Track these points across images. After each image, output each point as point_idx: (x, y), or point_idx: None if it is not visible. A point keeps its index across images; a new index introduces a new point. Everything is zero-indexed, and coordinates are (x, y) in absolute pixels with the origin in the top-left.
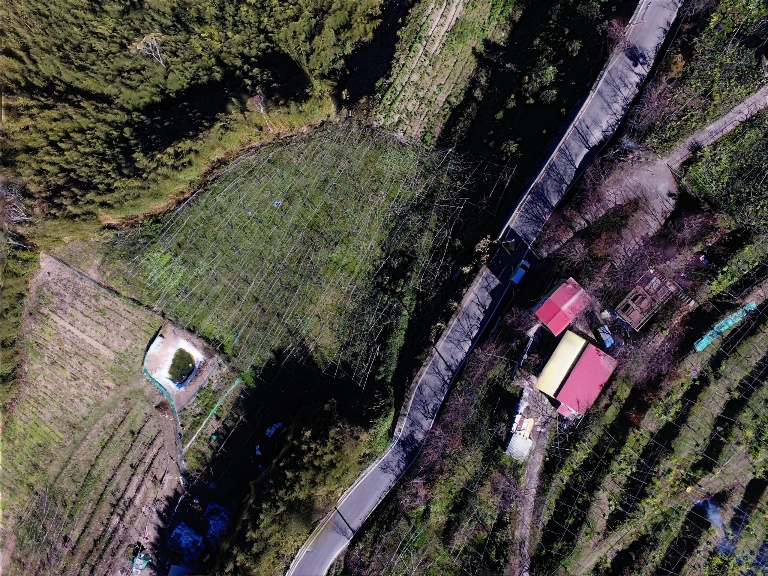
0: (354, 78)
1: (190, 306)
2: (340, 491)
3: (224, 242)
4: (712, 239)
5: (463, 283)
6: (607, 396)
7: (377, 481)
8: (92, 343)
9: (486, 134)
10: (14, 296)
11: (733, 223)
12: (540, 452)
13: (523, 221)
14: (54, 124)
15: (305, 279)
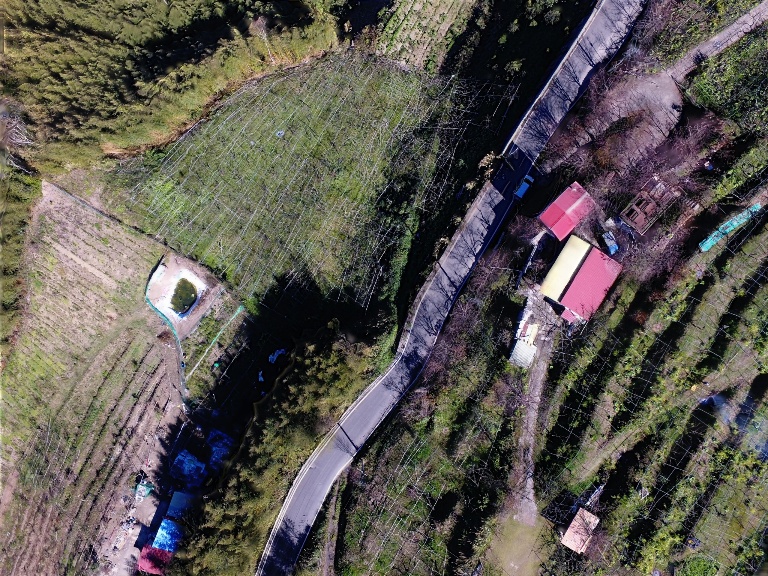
0: (356, 13)
1: (192, 234)
2: (343, 407)
3: (226, 171)
4: (717, 146)
5: (466, 200)
6: (611, 301)
7: (380, 398)
8: (94, 272)
9: (489, 60)
10: (16, 223)
11: (738, 129)
12: (544, 360)
13: (527, 137)
14: (56, 56)
15: (308, 206)
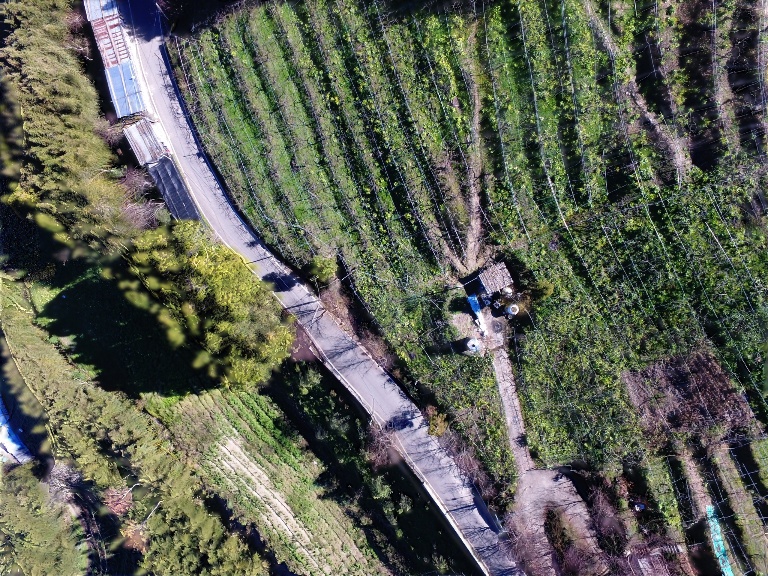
0: None
1: None
2: None
3: None
4: (622, 489)
5: None
6: None
7: None
8: None
9: None
10: None
11: (615, 464)
12: None
13: None
14: None
15: None
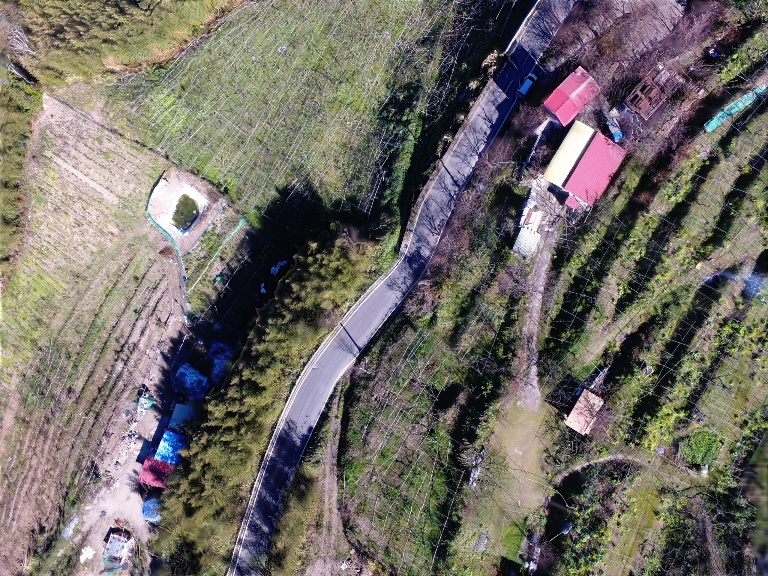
0: None
1: (194, 148)
2: (346, 307)
3: (228, 86)
4: (722, 34)
5: (469, 100)
6: (616, 187)
7: (383, 298)
8: (96, 187)
9: None
10: (17, 136)
11: (743, 17)
12: (548, 251)
13: (530, 36)
14: None
15: (310, 119)
